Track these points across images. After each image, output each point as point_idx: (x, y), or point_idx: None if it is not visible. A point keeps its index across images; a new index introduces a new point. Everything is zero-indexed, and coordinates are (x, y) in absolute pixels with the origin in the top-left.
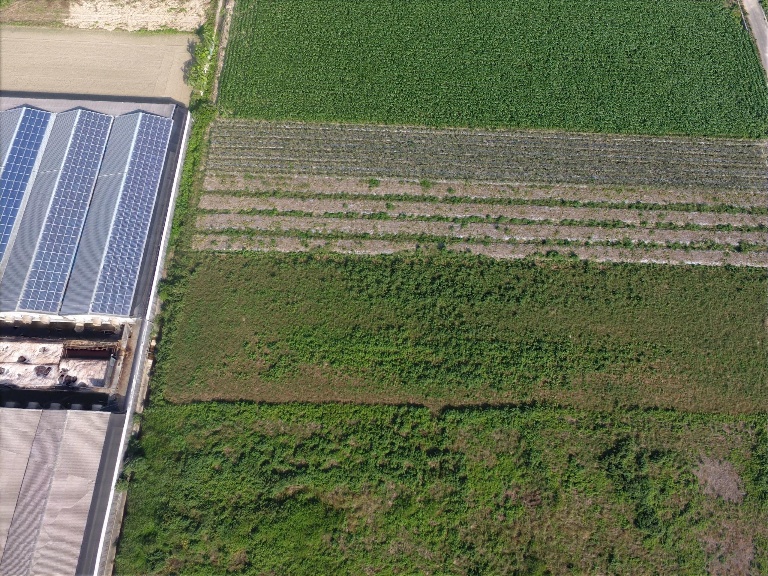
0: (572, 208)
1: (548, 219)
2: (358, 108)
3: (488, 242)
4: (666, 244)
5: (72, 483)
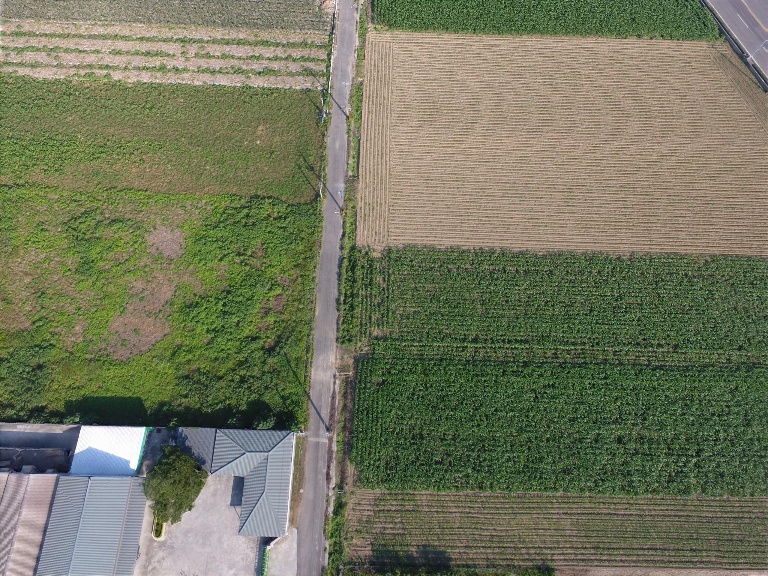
0: (123, 41)
1: (98, 49)
2: None
3: (37, 66)
4: (197, 69)
5: None
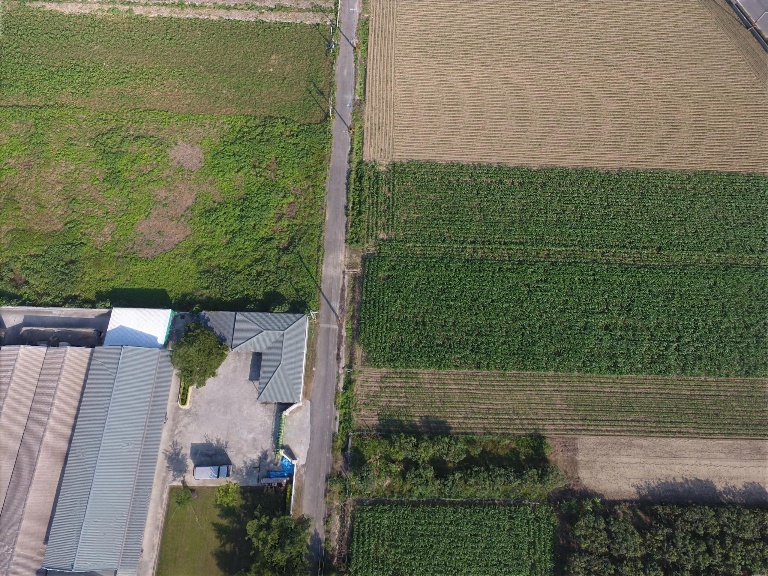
0: None
1: None
2: None
3: (63, 2)
4: (214, 6)
5: None
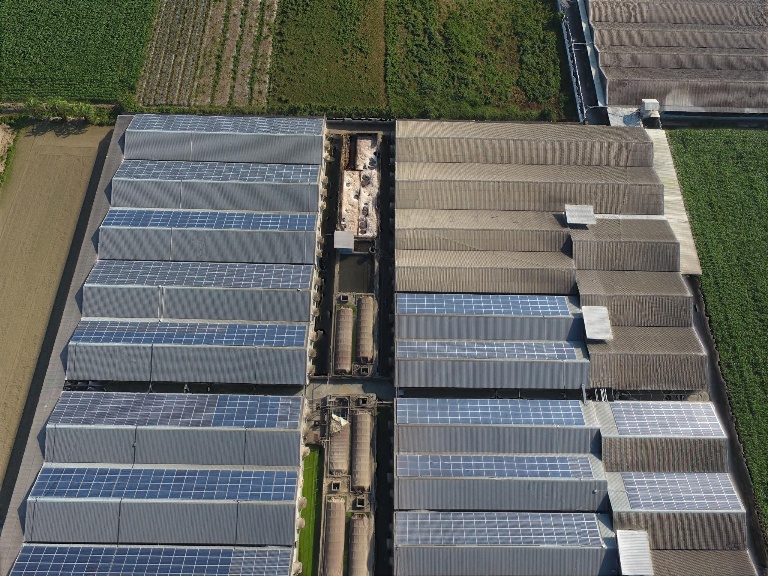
0: None
1: None
2: (143, 5)
3: None
4: None
5: (444, 130)
